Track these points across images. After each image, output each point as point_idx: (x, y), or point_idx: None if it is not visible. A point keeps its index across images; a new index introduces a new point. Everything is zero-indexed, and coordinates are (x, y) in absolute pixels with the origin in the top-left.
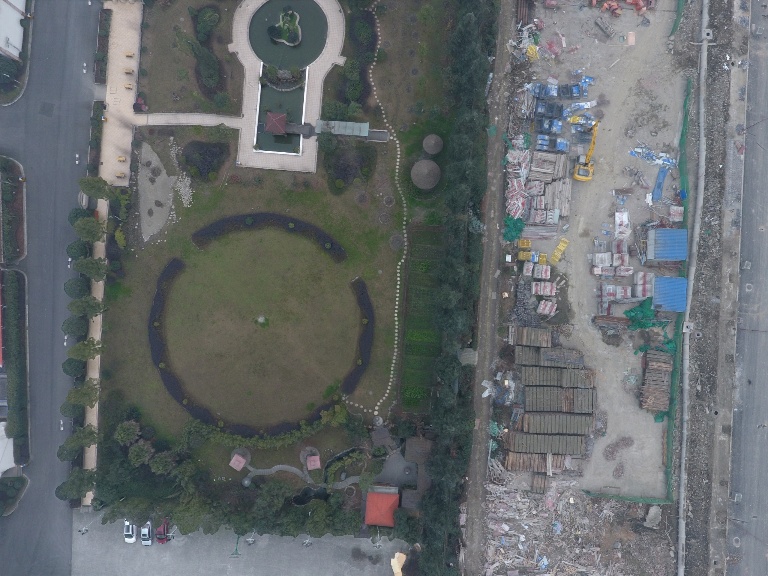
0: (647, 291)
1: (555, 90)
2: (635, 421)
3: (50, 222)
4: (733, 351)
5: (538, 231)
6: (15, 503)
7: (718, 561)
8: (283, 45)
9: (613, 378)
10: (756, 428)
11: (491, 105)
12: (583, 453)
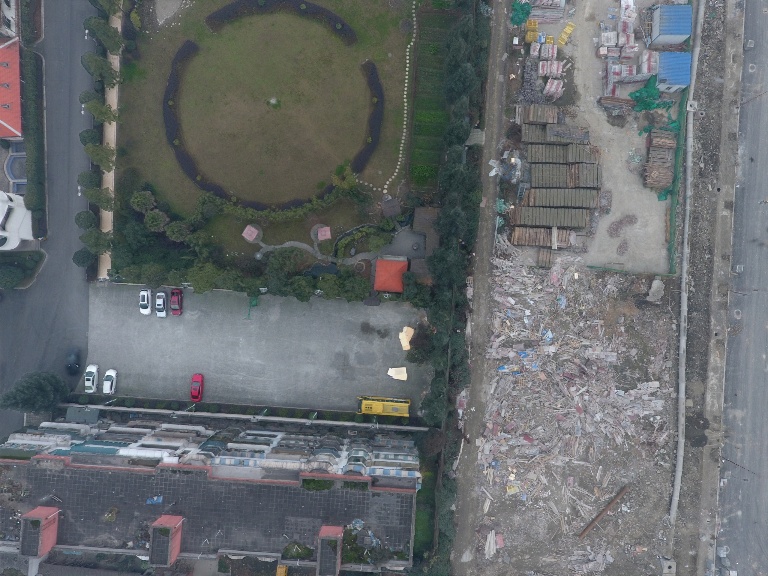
0: (652, 69)
1: None
2: (639, 200)
3: (67, 6)
4: (736, 129)
5: (545, 14)
6: (33, 276)
7: (719, 332)
8: None
9: (618, 158)
10: (758, 204)
11: None
12: (588, 230)
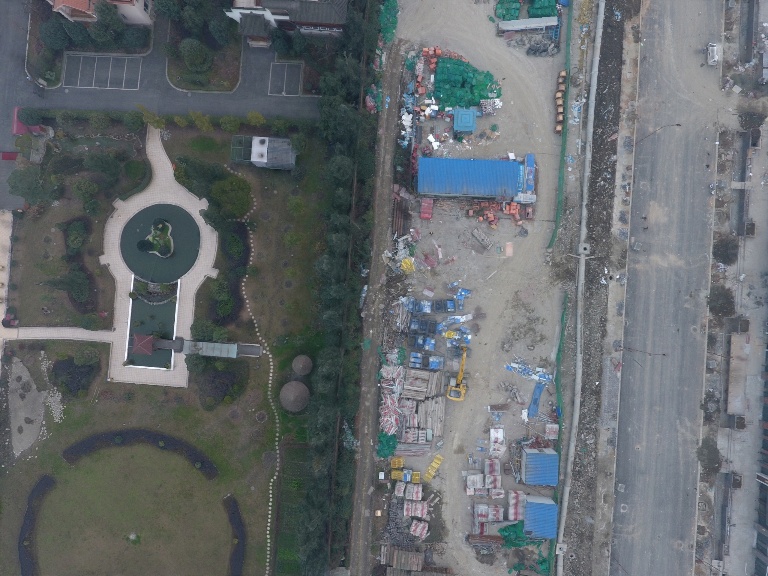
0: (519, 514)
1: (428, 307)
2: None
3: None
4: (607, 573)
5: (412, 448)
6: None
7: None
8: (155, 256)
9: None
10: None
11: (366, 318)
12: None
